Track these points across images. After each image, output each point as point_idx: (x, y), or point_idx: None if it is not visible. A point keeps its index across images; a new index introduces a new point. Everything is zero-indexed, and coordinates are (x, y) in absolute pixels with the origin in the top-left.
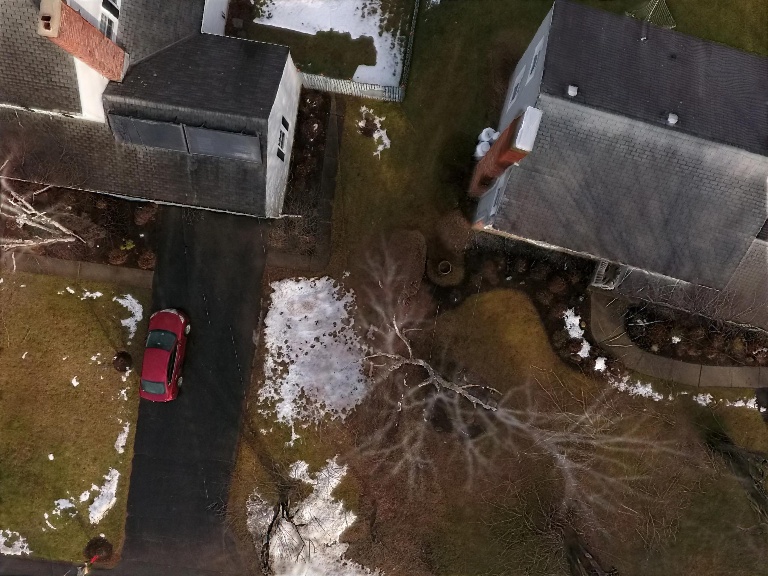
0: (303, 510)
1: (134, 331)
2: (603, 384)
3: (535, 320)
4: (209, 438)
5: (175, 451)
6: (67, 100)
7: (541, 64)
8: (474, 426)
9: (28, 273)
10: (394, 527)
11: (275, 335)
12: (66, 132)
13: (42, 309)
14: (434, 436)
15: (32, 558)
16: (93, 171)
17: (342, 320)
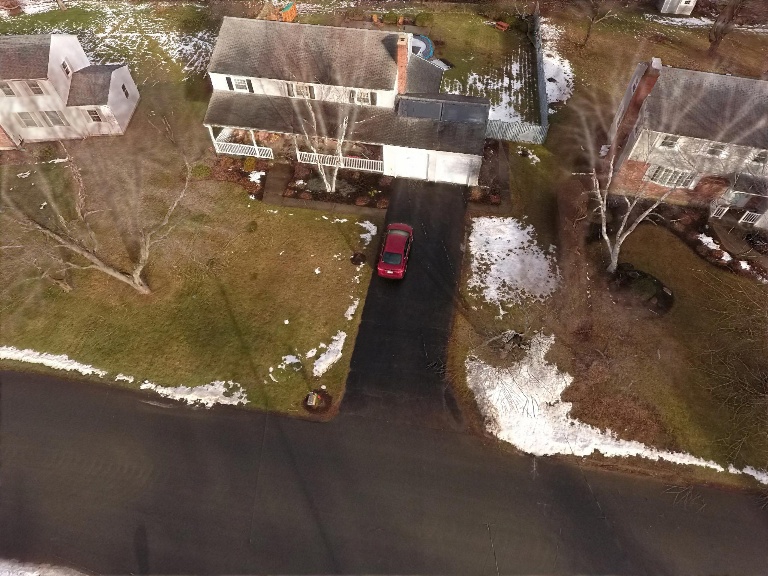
0: (521, 369)
1: (369, 241)
2: (754, 280)
3: (677, 241)
4: (428, 311)
5: (398, 320)
6: (387, 84)
7: (643, 73)
8: (658, 307)
9: (297, 208)
10: (613, 388)
11: (478, 247)
12: (368, 113)
13: (302, 227)
14: (626, 315)
15: (248, 408)
16: (377, 132)
17: (528, 241)
